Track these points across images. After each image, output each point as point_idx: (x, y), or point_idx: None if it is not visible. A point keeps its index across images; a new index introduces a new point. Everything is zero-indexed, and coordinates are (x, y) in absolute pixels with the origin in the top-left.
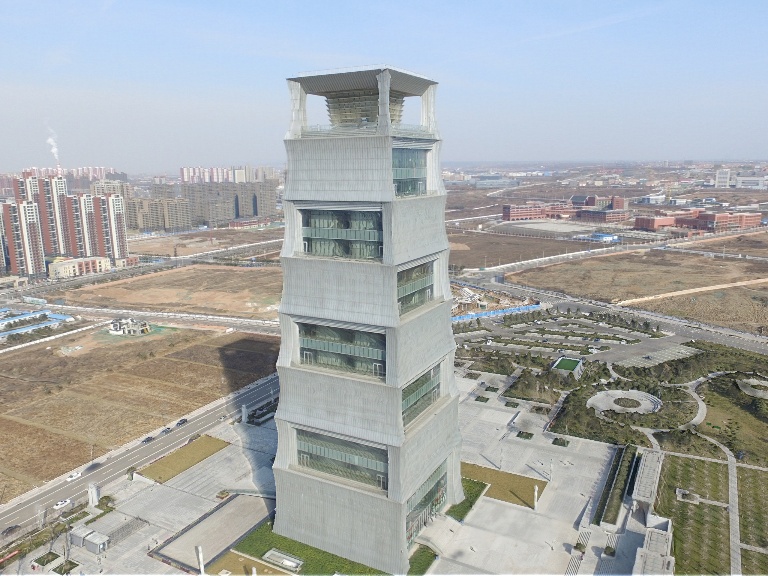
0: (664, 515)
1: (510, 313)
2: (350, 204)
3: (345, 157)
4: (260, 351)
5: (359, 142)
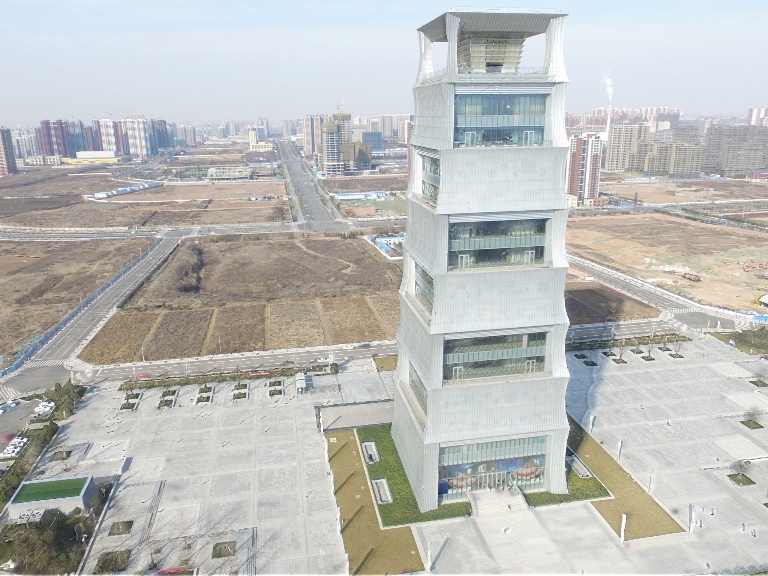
0: None
1: None
2: None
3: (430, 104)
4: (588, 303)
5: (434, 89)
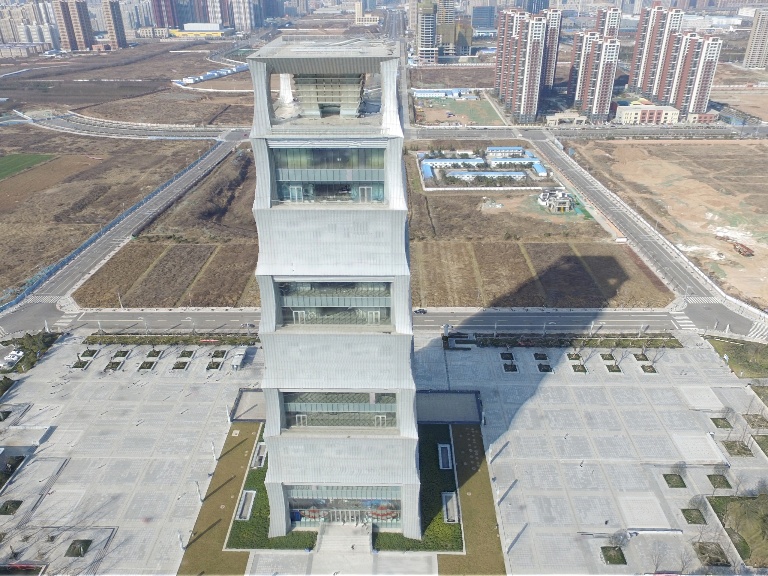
0: None
1: None
2: None
3: None
4: (597, 277)
5: None
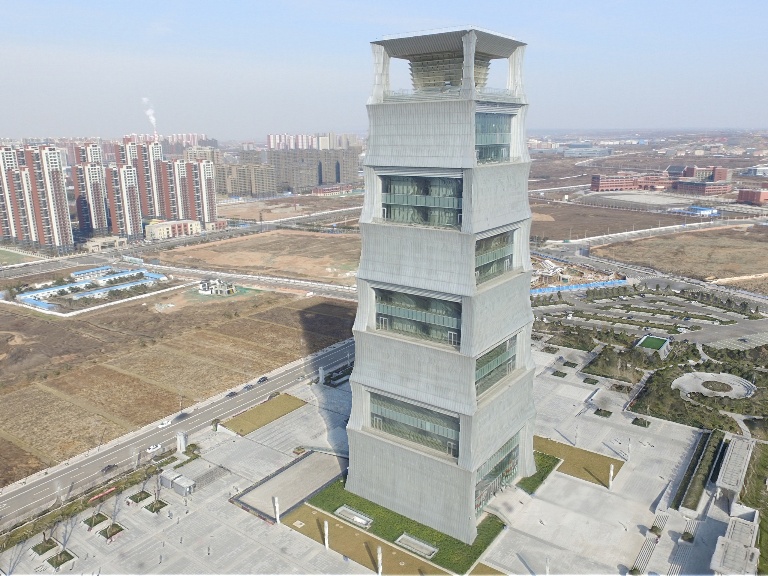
0: (751, 505)
1: (594, 287)
2: (430, 170)
3: (427, 122)
4: (338, 315)
5: (441, 106)
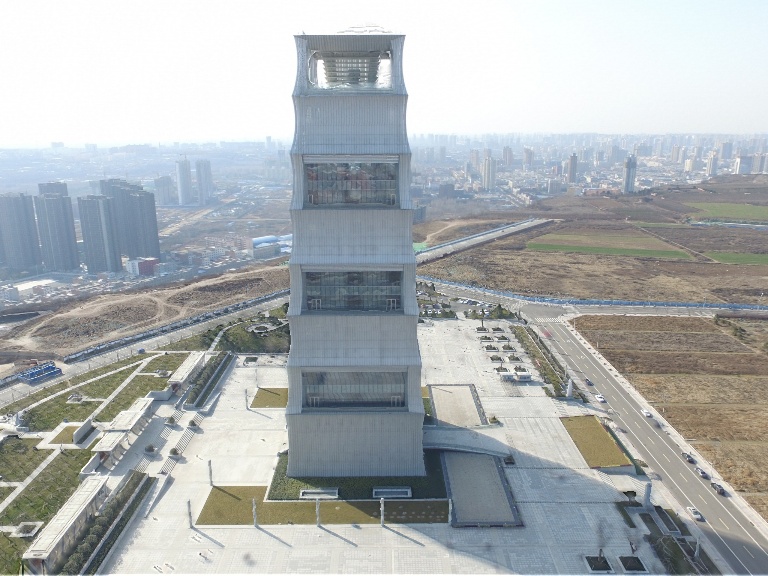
0: None
1: None
2: None
3: None
4: None
5: None
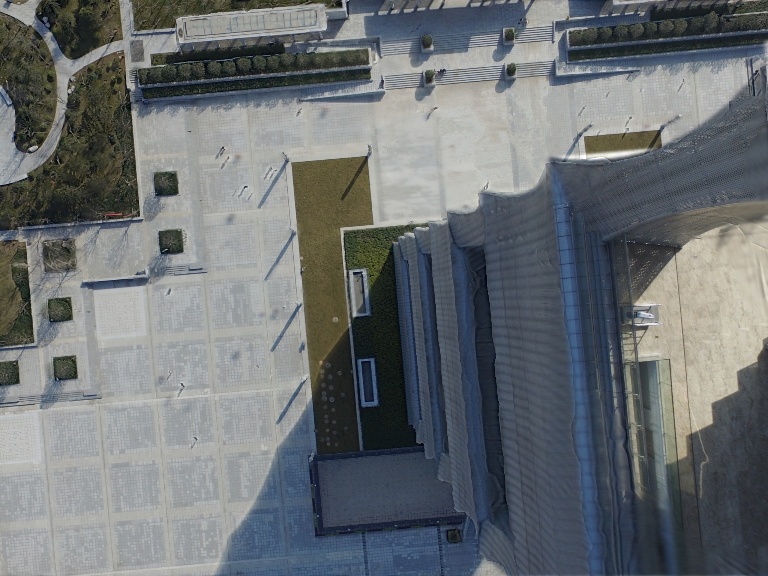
0: None
1: None
2: None
3: None
4: None
5: None
